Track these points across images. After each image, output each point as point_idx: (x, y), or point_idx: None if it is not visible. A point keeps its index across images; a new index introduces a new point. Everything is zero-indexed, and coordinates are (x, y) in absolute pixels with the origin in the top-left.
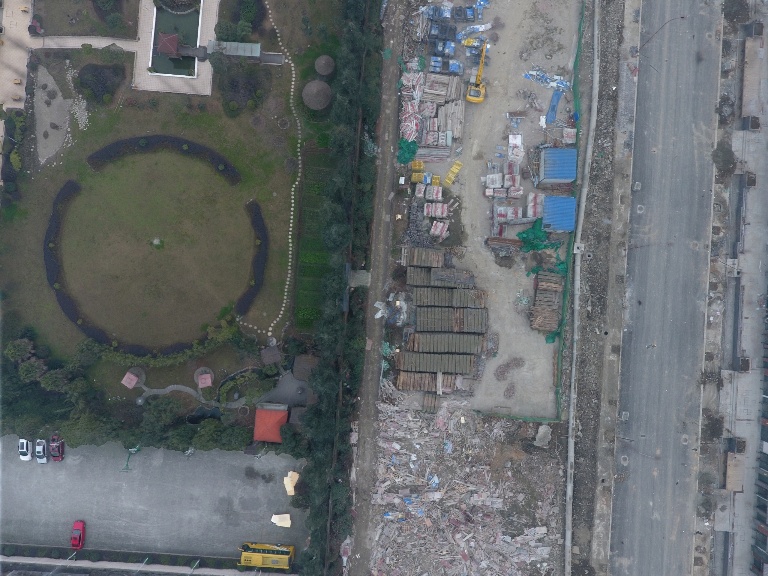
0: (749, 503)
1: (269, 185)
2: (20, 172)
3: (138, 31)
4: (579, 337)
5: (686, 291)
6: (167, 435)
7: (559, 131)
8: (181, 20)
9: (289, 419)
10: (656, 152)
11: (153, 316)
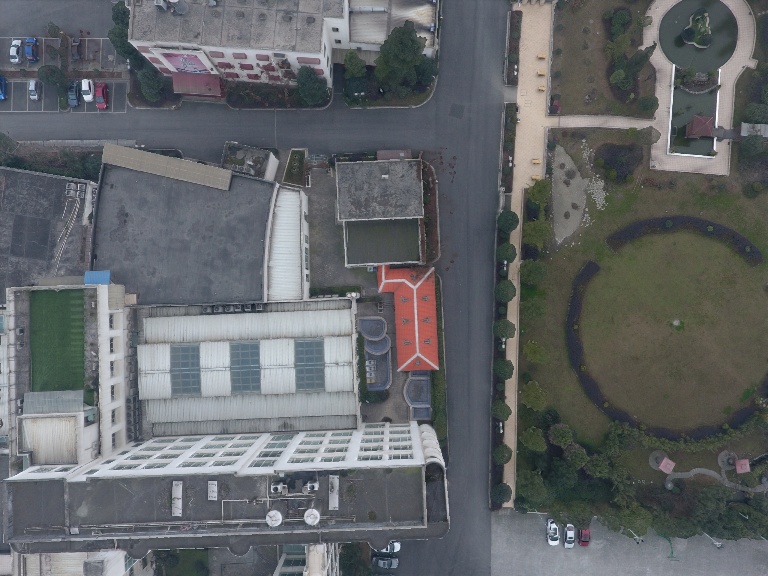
0: None
1: None
2: (540, 252)
3: None
4: None
5: None
6: (731, 525)
7: None
8: (696, 99)
9: None
10: None
11: (675, 398)
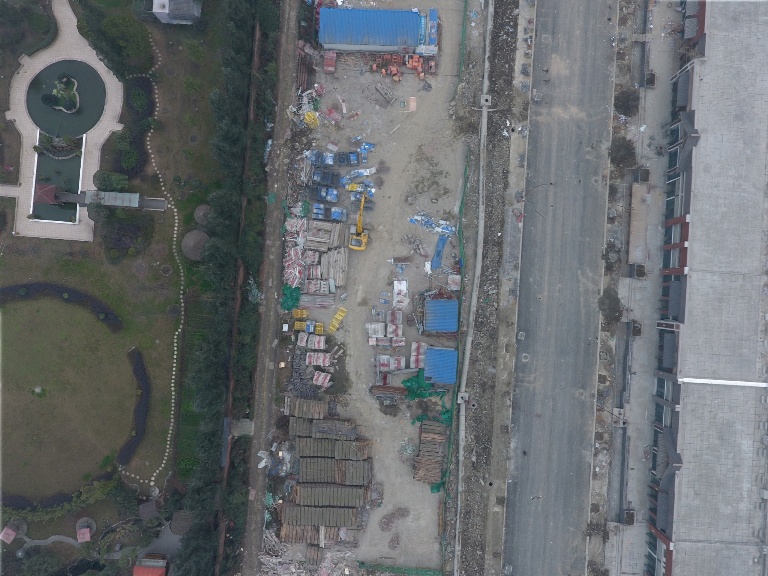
0: None
1: (152, 332)
2: None
3: (19, 176)
4: (463, 488)
5: (572, 441)
6: None
7: (445, 277)
8: (63, 165)
9: None
10: (541, 299)
11: (35, 466)
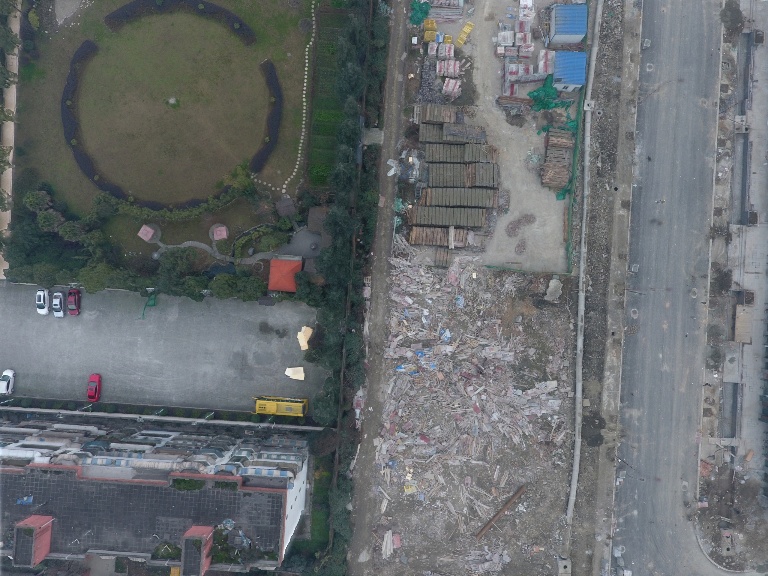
0: (757, 354)
1: (283, 45)
2: (38, 32)
3: None
4: (589, 192)
5: (695, 148)
6: (183, 280)
7: None
8: None
9: (303, 268)
10: (665, 12)
11: (169, 174)
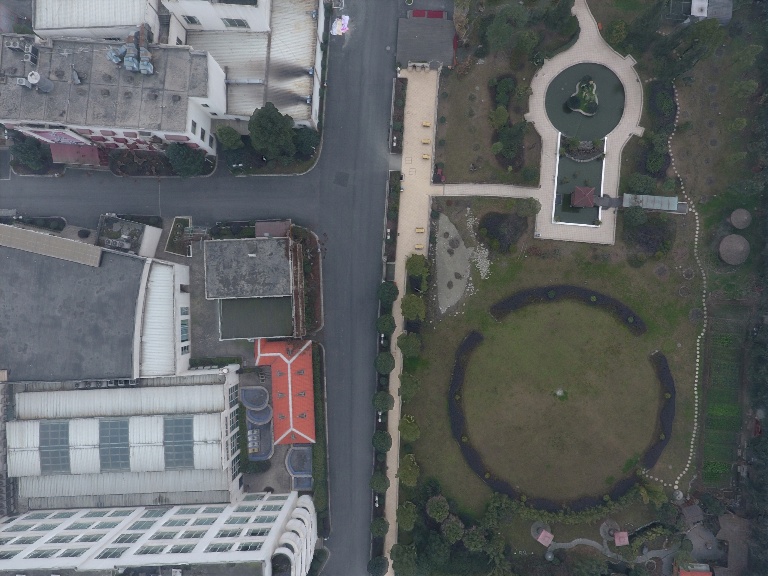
0: None
1: (674, 336)
2: (423, 322)
3: (540, 179)
4: None
5: None
6: None
7: None
8: (582, 168)
9: None
10: None
11: (557, 468)
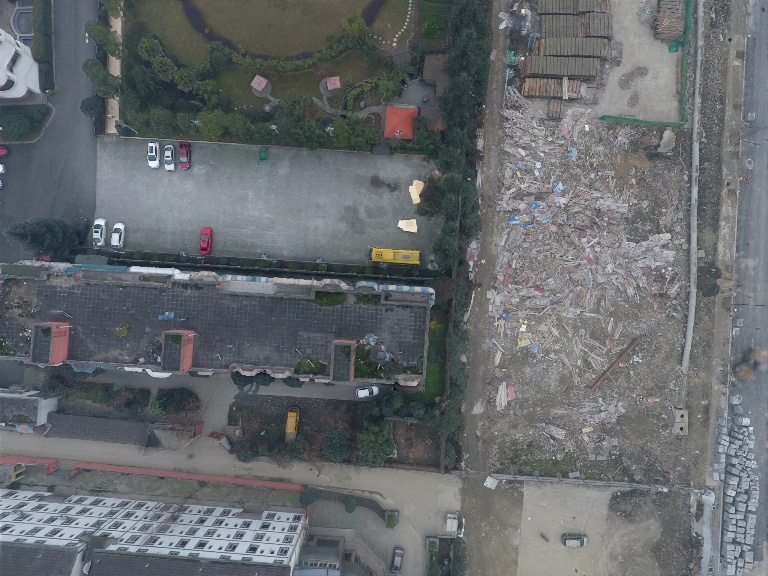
0: None
1: None
2: None
3: None
4: (703, 43)
5: None
6: (302, 122)
7: None
8: None
9: (420, 114)
10: None
11: (278, 27)
